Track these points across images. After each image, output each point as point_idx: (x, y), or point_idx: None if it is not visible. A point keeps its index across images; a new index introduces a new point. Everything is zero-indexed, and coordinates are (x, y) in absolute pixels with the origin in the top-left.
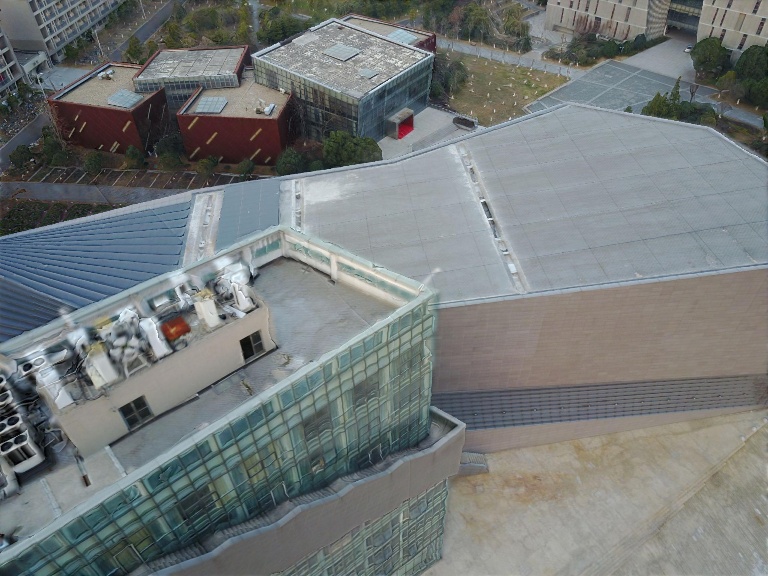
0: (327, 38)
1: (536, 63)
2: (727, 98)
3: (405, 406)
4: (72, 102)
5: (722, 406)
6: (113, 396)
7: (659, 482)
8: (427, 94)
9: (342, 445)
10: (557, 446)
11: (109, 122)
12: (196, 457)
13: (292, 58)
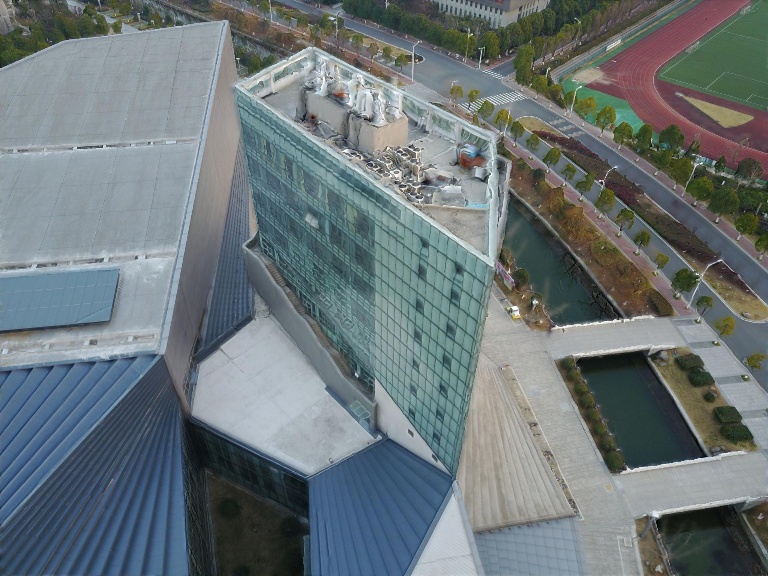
0: None
1: None
2: None
3: None
4: None
5: None
6: None
7: None
8: None
9: None
10: None
11: None
12: None
13: None
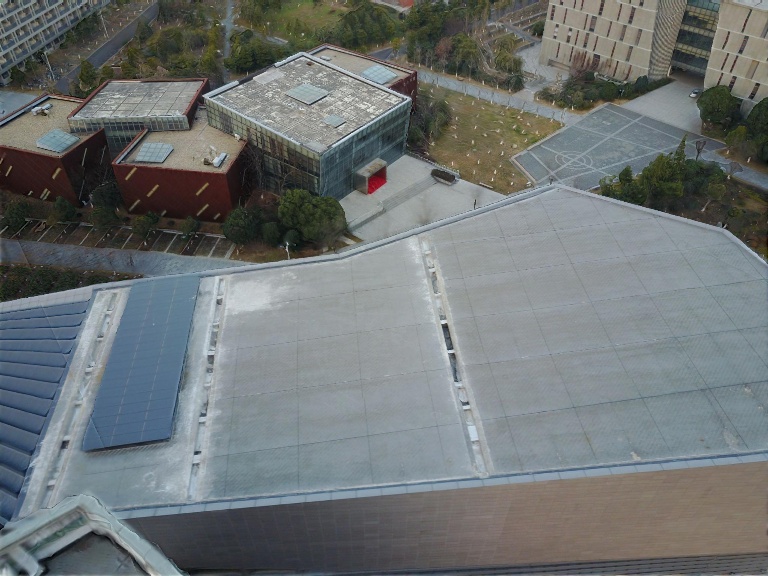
0: (293, 76)
1: (528, 104)
2: (736, 154)
3: None
4: None
5: None
6: None
7: None
8: (404, 141)
9: None
10: None
11: (37, 168)
12: None
13: (250, 100)
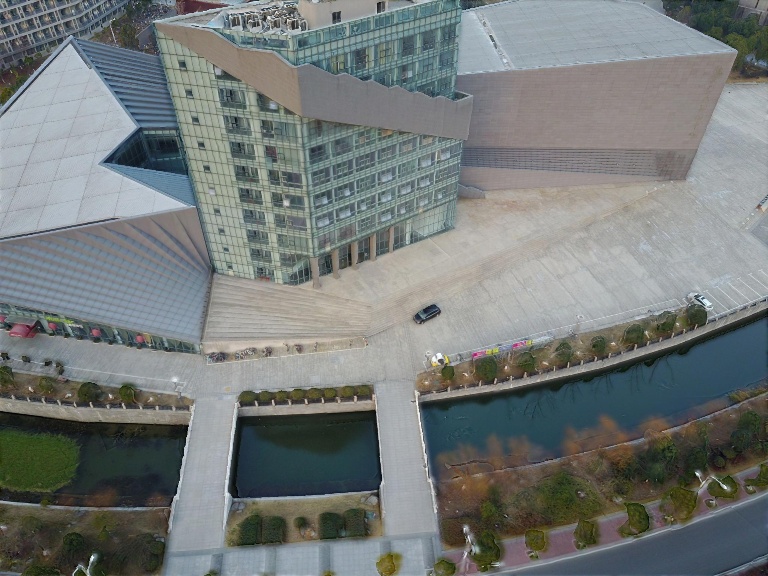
0: None
1: None
2: None
3: (445, 67)
4: (194, 0)
5: (636, 174)
6: (332, 5)
7: (590, 207)
8: None
9: (415, 72)
10: (529, 190)
11: None
12: (365, 28)
13: None
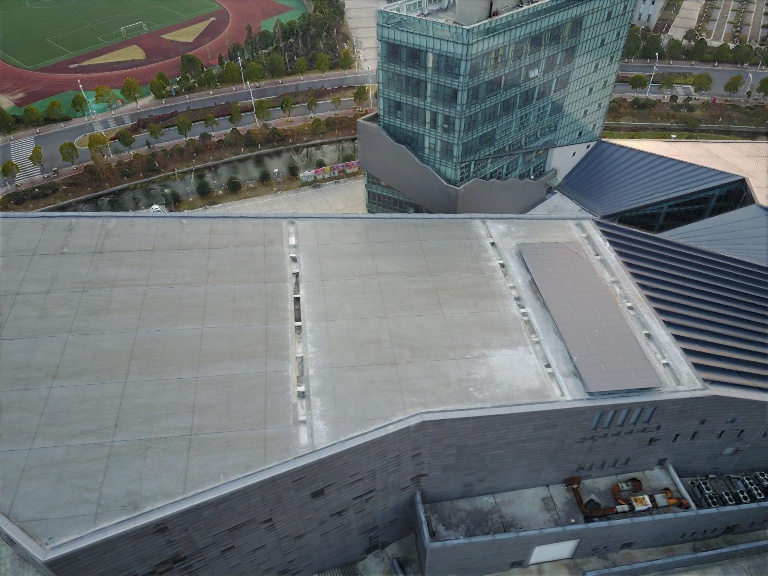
0: None
1: None
2: None
3: None
4: None
5: None
6: None
7: None
8: None
9: None
10: None
11: None
12: None
13: None
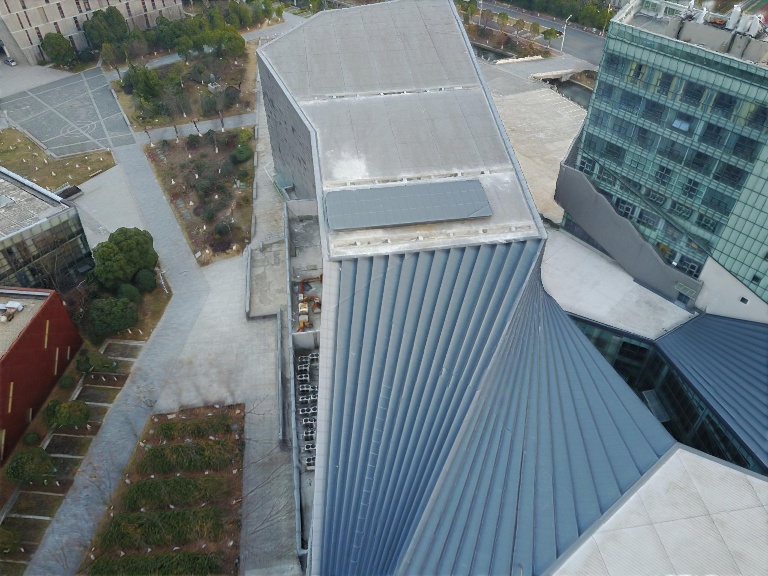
0: None
1: None
2: None
3: None
4: None
5: None
6: None
7: None
8: None
9: None
10: None
11: None
12: None
13: None
